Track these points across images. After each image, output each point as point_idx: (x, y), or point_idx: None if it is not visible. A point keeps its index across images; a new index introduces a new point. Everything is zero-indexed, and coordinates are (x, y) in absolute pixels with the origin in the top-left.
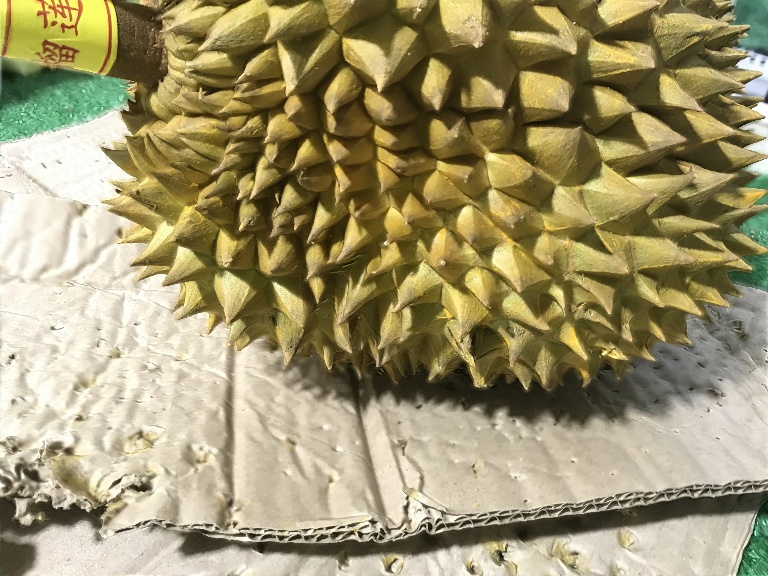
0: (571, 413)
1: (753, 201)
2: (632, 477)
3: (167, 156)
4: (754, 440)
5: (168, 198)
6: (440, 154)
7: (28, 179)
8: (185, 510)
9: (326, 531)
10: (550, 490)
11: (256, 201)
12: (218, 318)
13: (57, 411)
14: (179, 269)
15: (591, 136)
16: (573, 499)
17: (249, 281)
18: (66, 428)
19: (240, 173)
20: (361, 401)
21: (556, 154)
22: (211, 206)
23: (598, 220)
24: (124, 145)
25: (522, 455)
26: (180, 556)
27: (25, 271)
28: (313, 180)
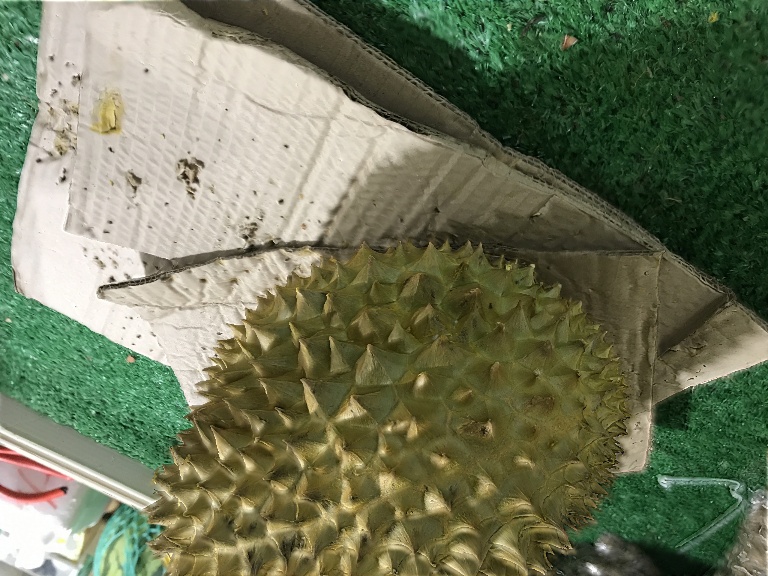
0: None
1: None
2: None
3: None
4: None
5: None
6: None
7: None
8: None
9: None
10: None
11: None
12: None
13: None
14: None
15: None
16: None
17: None
18: None
19: None
20: None
21: None
22: None
23: None
24: None
25: None
26: None
27: None
28: None
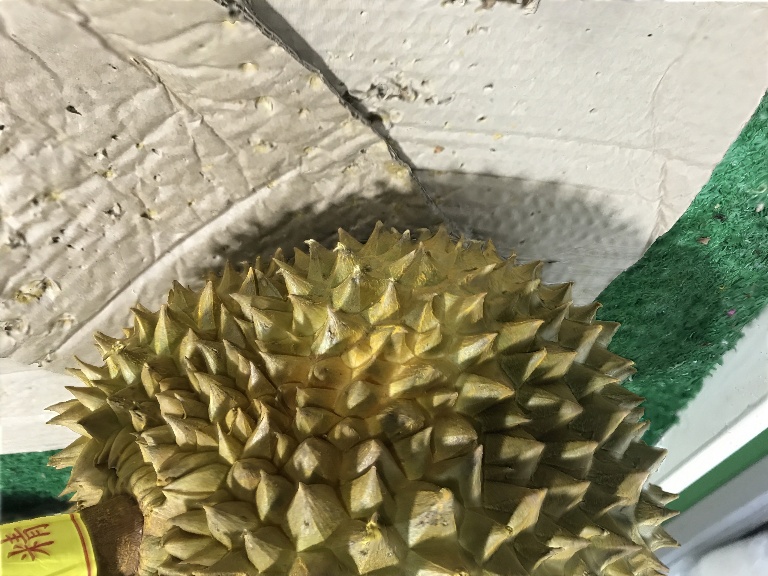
0: None
1: None
2: None
3: None
4: None
5: None
6: None
7: None
8: (18, 353)
9: None
10: None
11: None
12: None
13: (2, 212)
14: None
15: None
16: None
17: None
18: None
19: None
20: None
21: None
22: None
23: None
24: (112, 408)
25: None
26: None
27: (96, 19)
28: None
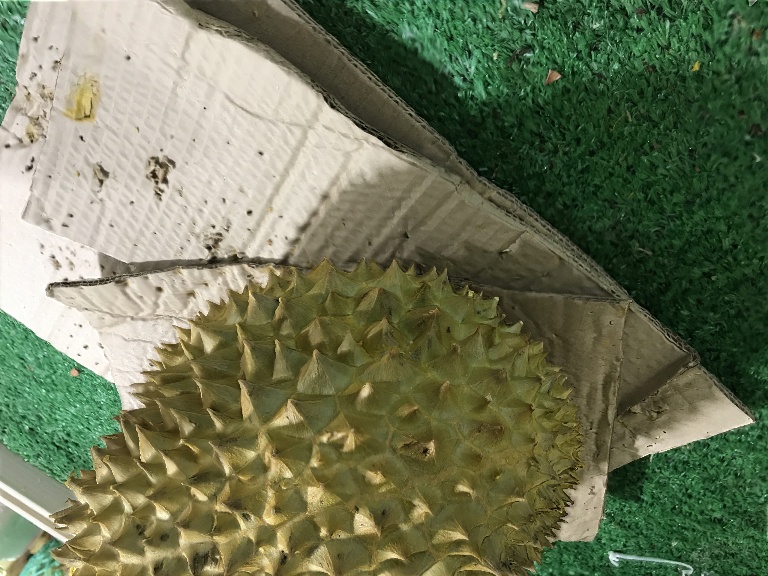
0: None
1: None
2: None
3: None
4: None
5: None
6: None
7: None
8: None
9: None
10: None
11: None
12: None
13: None
14: None
15: None
16: None
17: None
18: None
19: None
20: None
21: None
22: None
23: None
24: None
25: None
26: None
27: None
28: None
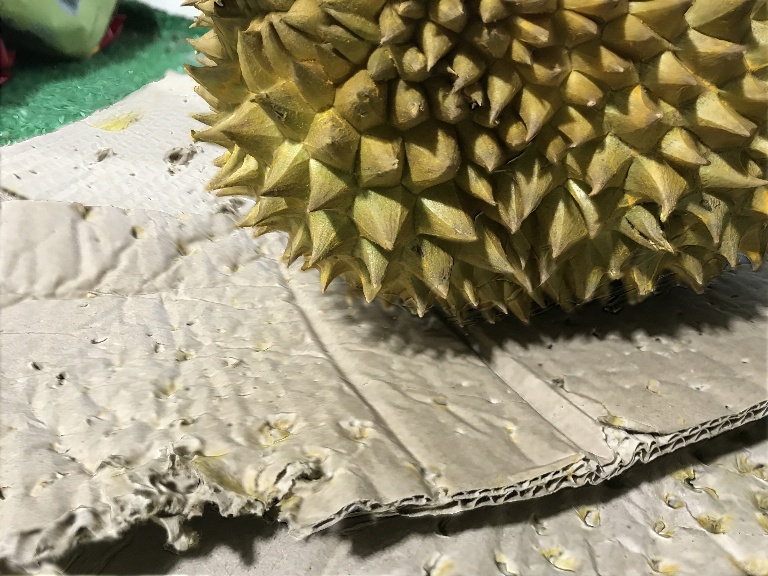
0: (709, 322)
1: None
2: None
3: (293, 50)
4: None
5: (298, 104)
6: None
7: (2, 193)
8: (382, 486)
9: (541, 481)
10: (745, 391)
11: (418, 84)
12: (335, 270)
13: (148, 423)
14: (321, 191)
15: None
16: None
17: (399, 198)
18: (174, 436)
19: (400, 49)
20: (481, 355)
21: None
22: (370, 93)
23: None
24: None
25: (690, 367)
26: (357, 560)
27: (35, 287)
28: (501, 37)
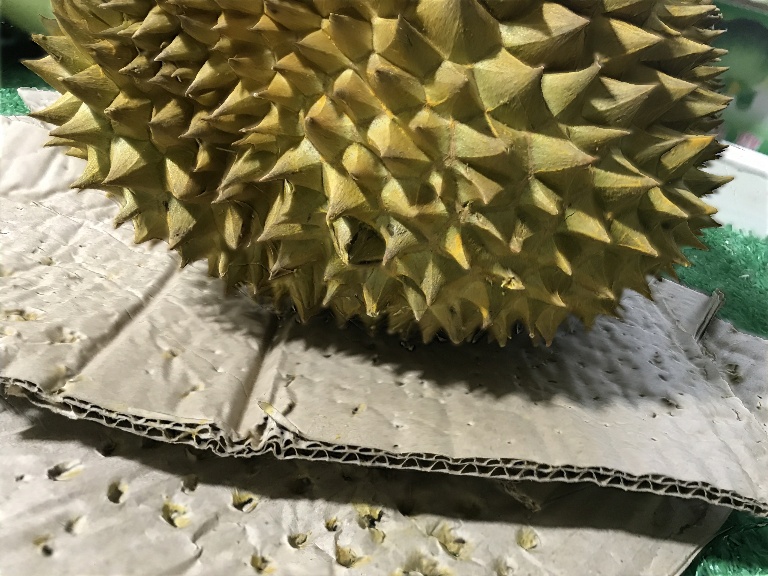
0: (490, 387)
1: (699, 148)
2: (530, 448)
3: None
4: (698, 449)
5: (75, 52)
6: (321, 6)
7: (38, 121)
8: (15, 367)
9: (160, 425)
10: (428, 441)
11: (148, 53)
12: None
13: None
14: (72, 124)
15: (492, 17)
16: (451, 453)
17: (141, 151)
18: None
19: (134, 20)
20: (271, 344)
21: (441, 17)
22: (101, 49)
23: (489, 105)
24: None
25: (414, 409)
26: (17, 438)
27: None
28: (193, 23)
